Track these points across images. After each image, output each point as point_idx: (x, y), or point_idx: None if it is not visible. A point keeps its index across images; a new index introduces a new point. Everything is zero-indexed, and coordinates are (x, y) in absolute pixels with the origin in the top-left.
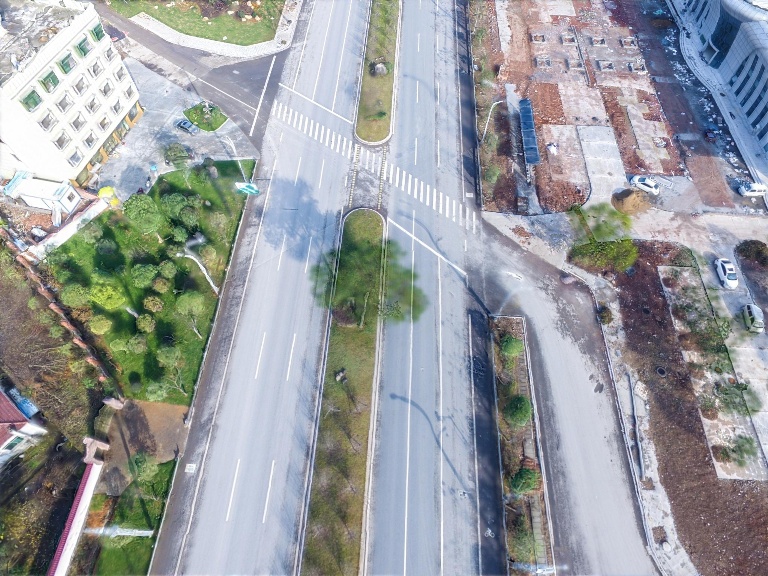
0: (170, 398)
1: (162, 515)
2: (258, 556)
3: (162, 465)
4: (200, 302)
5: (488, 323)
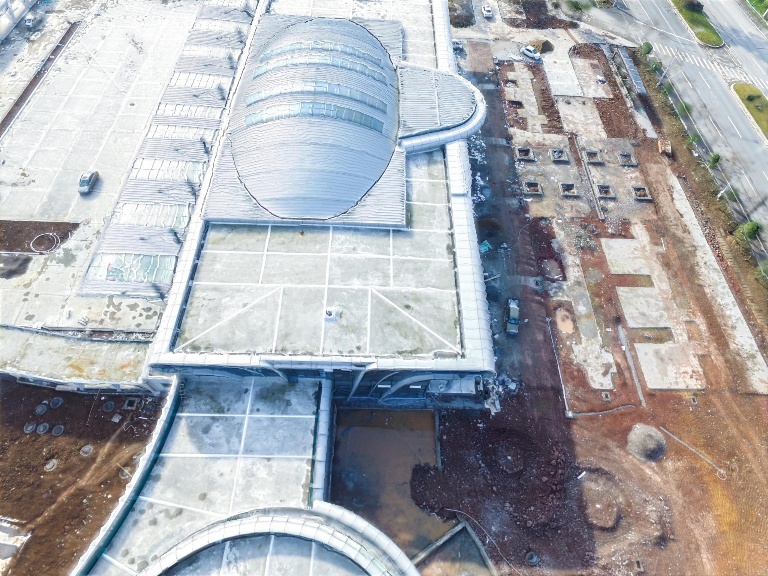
0: None
1: None
2: None
3: None
4: (767, 0)
5: (617, 6)
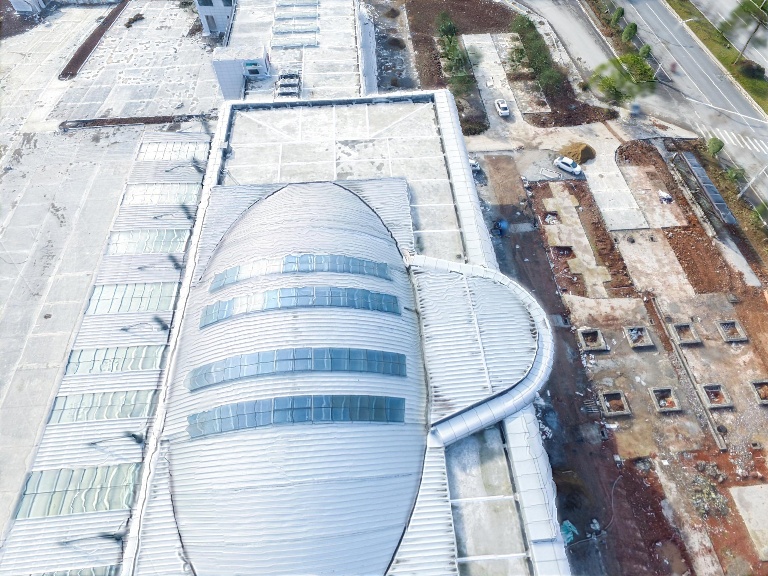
0: None
1: None
2: (712, 6)
3: None
4: None
5: (657, 78)
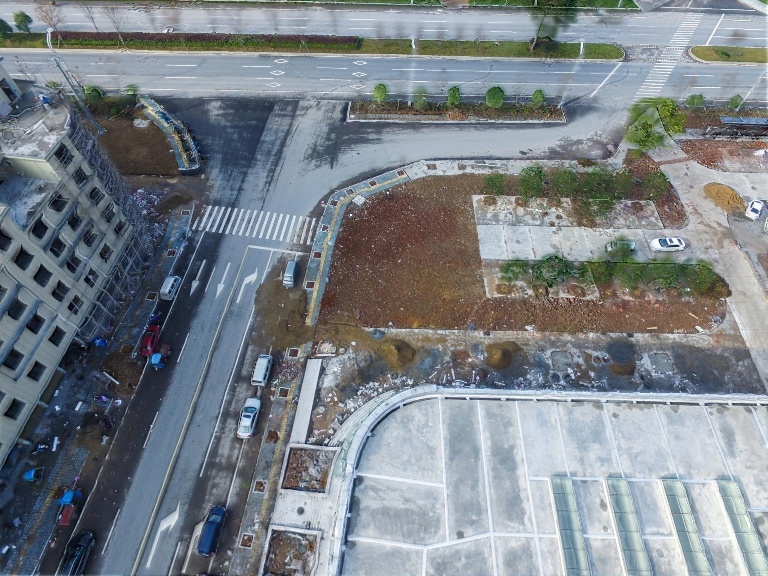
0: (471, 1)
1: (419, 4)
2: (406, 30)
3: (440, 3)
4: None
5: (555, 105)
